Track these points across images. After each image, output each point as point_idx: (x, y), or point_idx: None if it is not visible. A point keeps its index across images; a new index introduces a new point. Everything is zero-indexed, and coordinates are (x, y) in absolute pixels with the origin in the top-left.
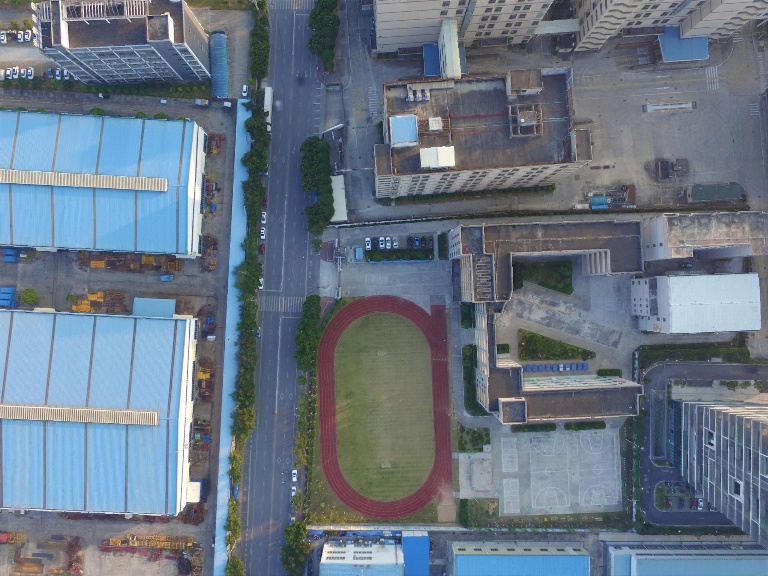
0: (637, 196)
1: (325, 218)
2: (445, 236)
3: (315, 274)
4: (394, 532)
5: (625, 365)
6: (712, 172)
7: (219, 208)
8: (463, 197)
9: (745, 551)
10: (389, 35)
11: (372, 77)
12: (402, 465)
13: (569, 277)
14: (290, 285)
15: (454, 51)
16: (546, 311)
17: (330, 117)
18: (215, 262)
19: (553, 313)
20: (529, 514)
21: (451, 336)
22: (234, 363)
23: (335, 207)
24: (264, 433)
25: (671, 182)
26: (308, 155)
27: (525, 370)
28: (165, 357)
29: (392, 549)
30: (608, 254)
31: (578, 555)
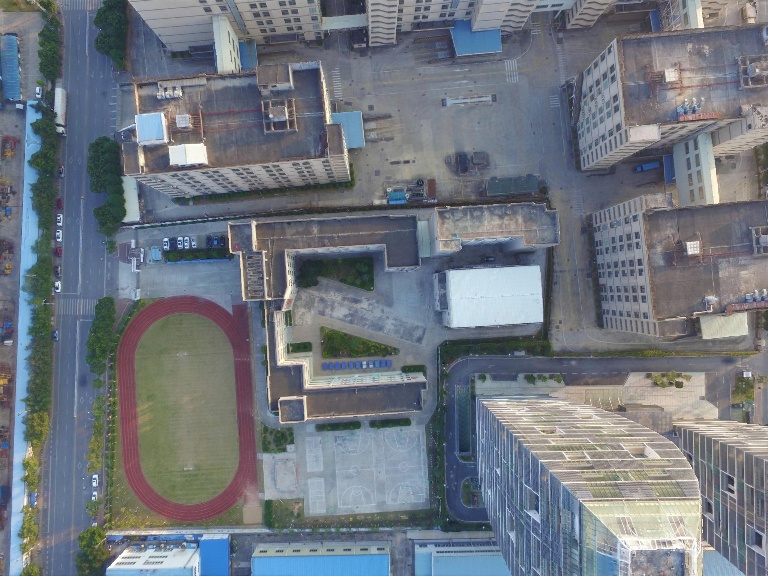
0: (438, 190)
1: (115, 219)
2: None
3: (114, 276)
4: (196, 535)
5: (430, 361)
6: (513, 165)
7: (15, 211)
8: (262, 195)
9: None
10: (168, 33)
11: (168, 76)
12: (206, 467)
13: (369, 273)
14: (88, 287)
15: (224, 48)
16: (348, 308)
17: (126, 117)
18: (10, 266)
19: (355, 310)
20: (335, 514)
21: (253, 335)
22: (23, 368)
23: (127, 208)
24: (64, 438)
25: (472, 176)
26: (93, 156)
27: (328, 368)
28: None
29: (190, 553)
30: None
31: (378, 554)
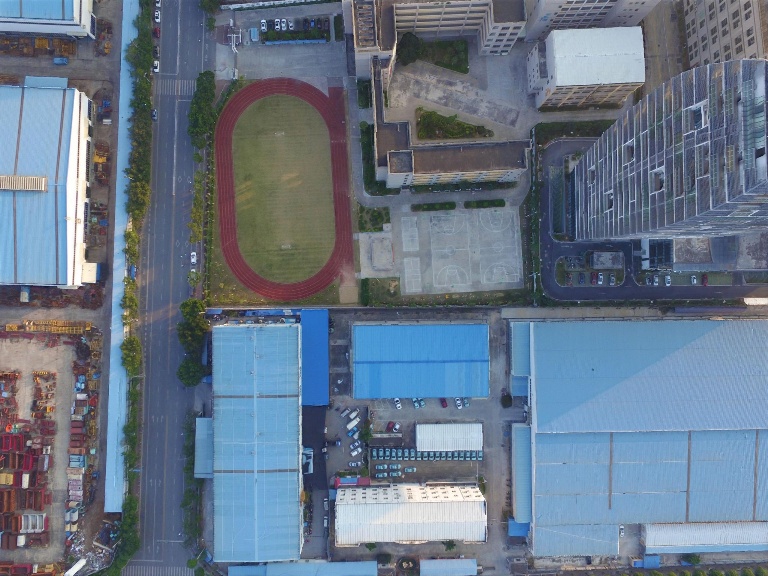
0: None
1: None
2: (341, 18)
3: (211, 57)
4: (294, 310)
5: None
6: None
7: None
8: None
9: (645, 320)
10: None
11: None
12: (303, 247)
13: (464, 54)
14: (186, 68)
15: None
16: (443, 91)
17: None
18: (109, 45)
19: (450, 92)
20: (431, 293)
21: (349, 117)
22: (126, 137)
23: None
24: (162, 216)
25: None
26: None
27: None
28: (53, 125)
29: None
30: (491, 5)
31: (477, 324)
